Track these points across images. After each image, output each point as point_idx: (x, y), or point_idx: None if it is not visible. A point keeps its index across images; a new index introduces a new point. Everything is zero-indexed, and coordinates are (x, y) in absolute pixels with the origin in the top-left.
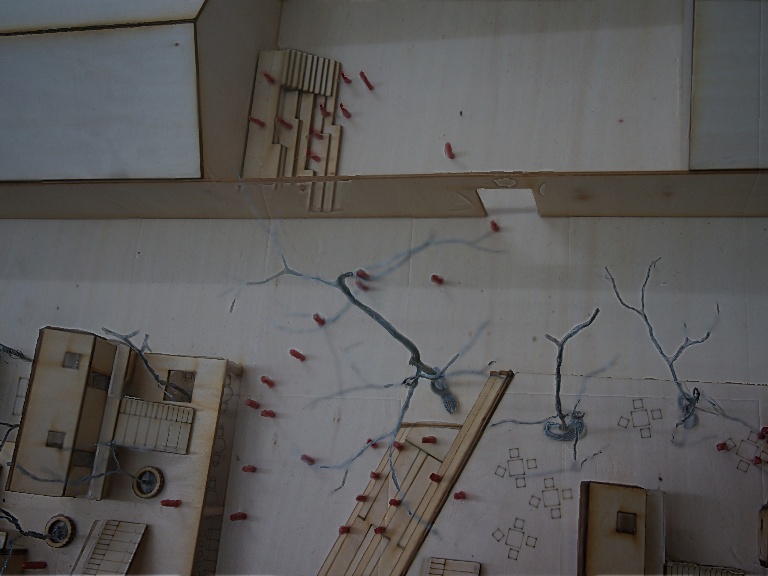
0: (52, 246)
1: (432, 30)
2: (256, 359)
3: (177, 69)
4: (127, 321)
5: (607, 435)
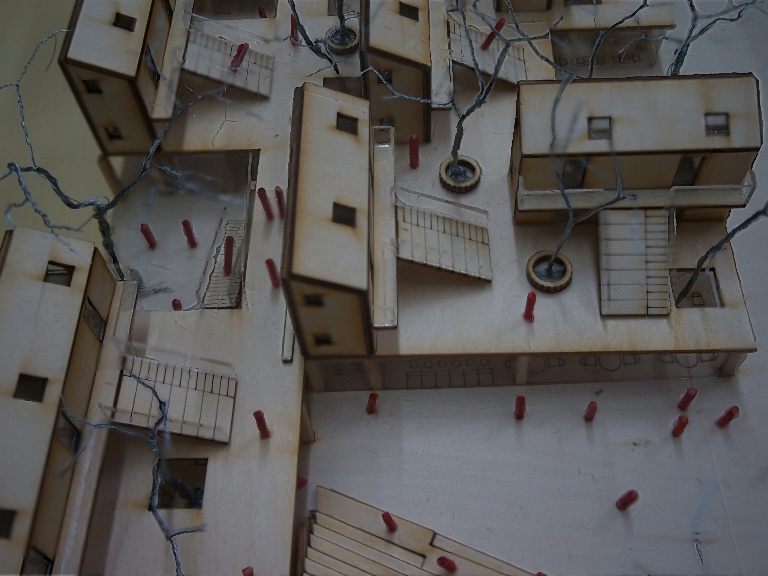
0: None
1: None
2: (752, 393)
3: None
4: None
5: None
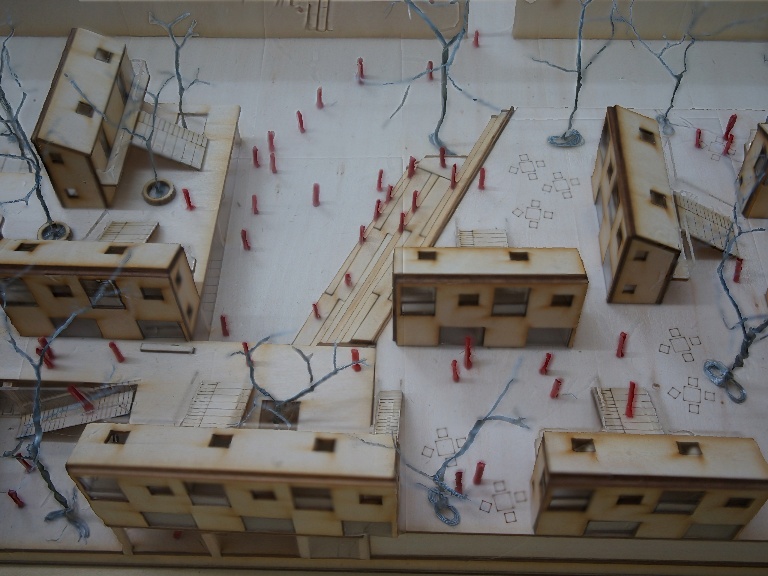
0: (29, 56)
1: None
2: (255, 133)
3: None
4: None
5: None
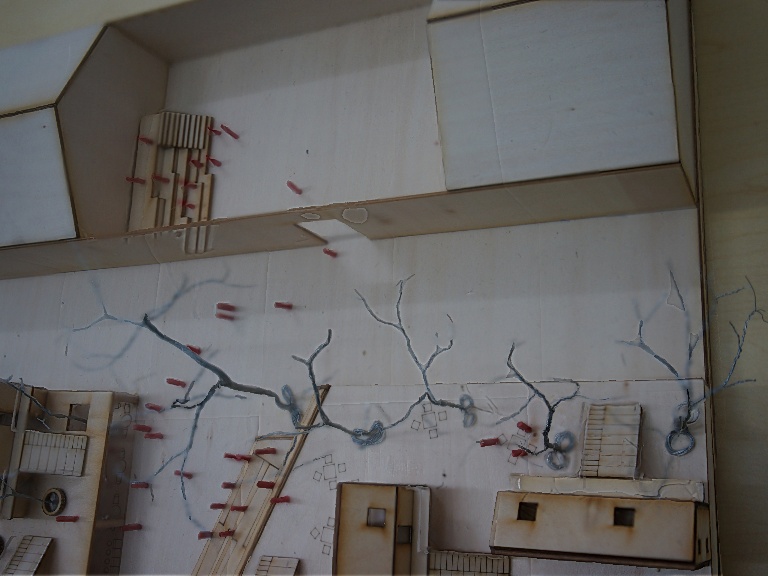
0: (0, 303)
1: (284, 78)
2: (149, 388)
3: (47, 147)
4: (54, 363)
5: (402, 438)
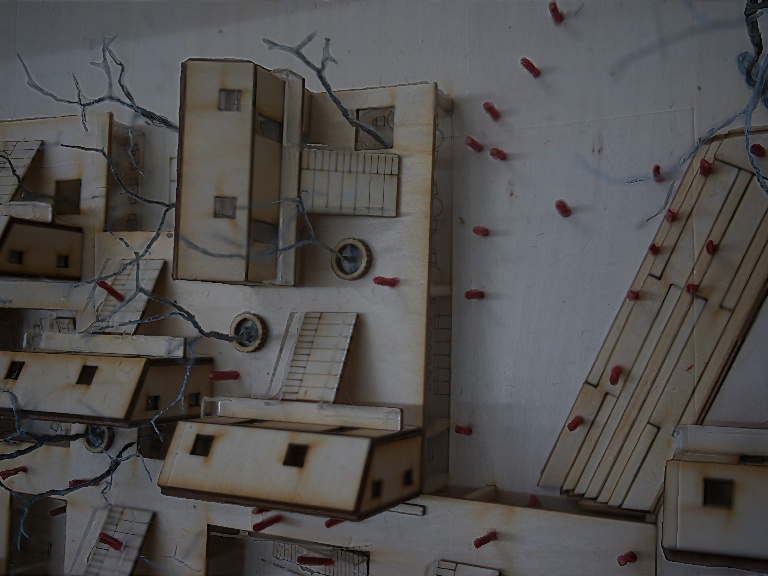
0: None
1: None
2: (470, 85)
3: None
4: (290, 65)
5: None
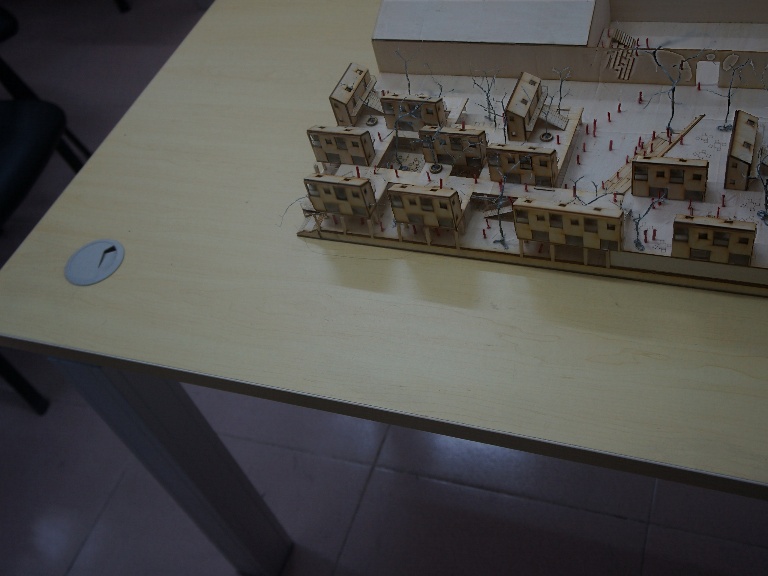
0: (495, 85)
1: (677, 34)
2: (588, 121)
3: (586, 9)
4: None
5: None
